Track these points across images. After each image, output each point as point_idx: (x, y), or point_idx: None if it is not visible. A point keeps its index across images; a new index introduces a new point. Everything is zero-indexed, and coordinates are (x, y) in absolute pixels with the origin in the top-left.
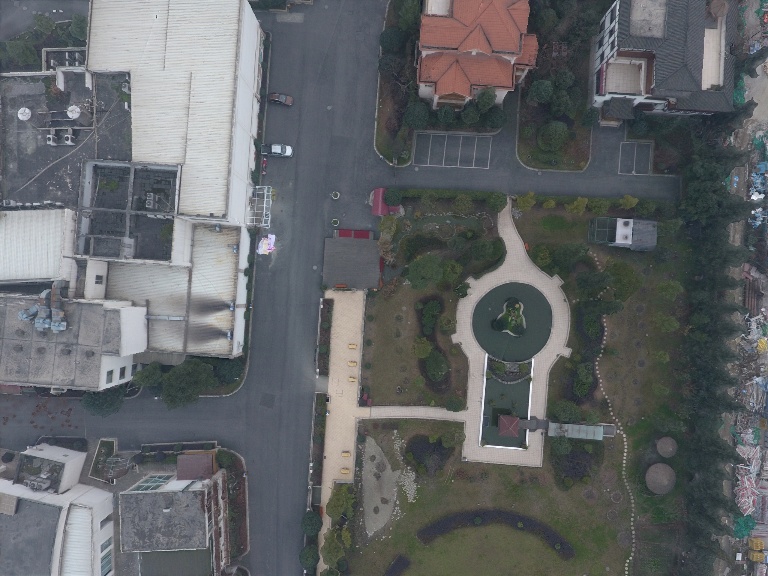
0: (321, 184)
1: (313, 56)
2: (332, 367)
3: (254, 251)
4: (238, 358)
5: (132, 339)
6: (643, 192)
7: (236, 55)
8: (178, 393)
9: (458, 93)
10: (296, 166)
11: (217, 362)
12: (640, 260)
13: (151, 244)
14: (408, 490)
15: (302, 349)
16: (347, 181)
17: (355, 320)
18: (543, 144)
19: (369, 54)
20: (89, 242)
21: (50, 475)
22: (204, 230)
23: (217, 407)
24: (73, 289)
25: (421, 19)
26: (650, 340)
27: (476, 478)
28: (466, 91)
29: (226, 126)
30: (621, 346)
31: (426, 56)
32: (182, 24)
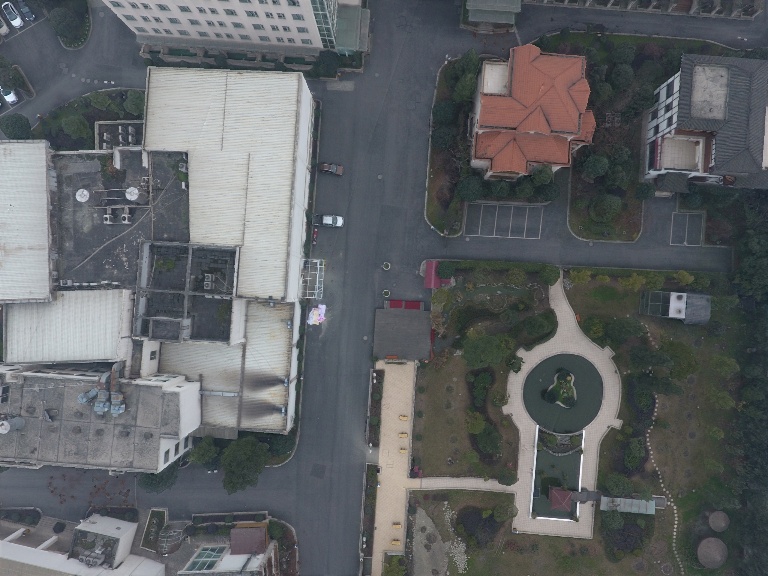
0: (371, 254)
1: (363, 125)
2: (383, 438)
3: (305, 321)
4: (290, 431)
5: (189, 418)
6: (695, 263)
7: (295, 136)
8: (240, 480)
9: (515, 171)
10: (346, 236)
11: (268, 433)
12: (691, 331)
13: (208, 324)
14: (459, 561)
15: (352, 420)
16: (398, 251)
17: (406, 391)
18: (595, 215)
19: (420, 123)
20: (146, 321)
21: (104, 550)
22: (258, 305)
23: (268, 477)
24: (129, 367)
25: (480, 99)
26: (701, 412)
27: (527, 550)
28: (522, 168)
29: (285, 208)
30: (672, 418)
31: (482, 133)
32: (240, 104)
